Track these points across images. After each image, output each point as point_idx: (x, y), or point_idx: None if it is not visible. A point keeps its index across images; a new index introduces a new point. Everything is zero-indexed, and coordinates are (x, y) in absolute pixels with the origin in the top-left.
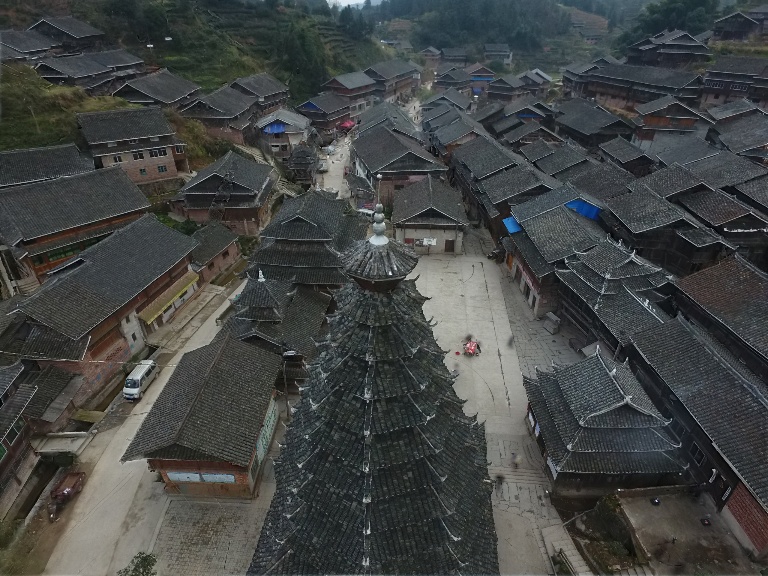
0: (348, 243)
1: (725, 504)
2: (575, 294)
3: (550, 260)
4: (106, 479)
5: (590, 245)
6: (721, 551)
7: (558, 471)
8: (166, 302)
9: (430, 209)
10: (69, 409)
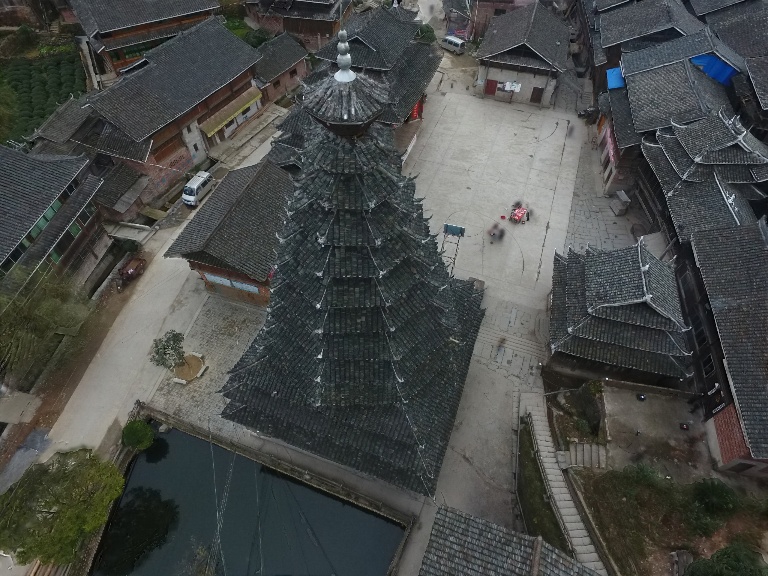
0: (410, 76)
1: (713, 417)
2: (654, 175)
3: (639, 129)
4: (162, 268)
5: (696, 117)
6: (686, 453)
7: (552, 349)
8: (227, 117)
9: (523, 45)
10: (138, 204)
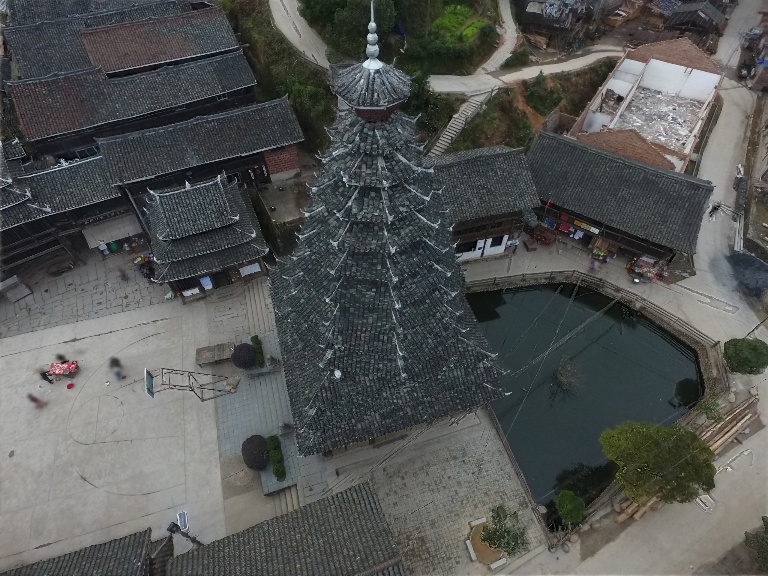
0: None
1: (270, 175)
2: (1, 234)
3: None
4: None
5: None
6: (299, 186)
7: None
8: None
9: None
10: None
